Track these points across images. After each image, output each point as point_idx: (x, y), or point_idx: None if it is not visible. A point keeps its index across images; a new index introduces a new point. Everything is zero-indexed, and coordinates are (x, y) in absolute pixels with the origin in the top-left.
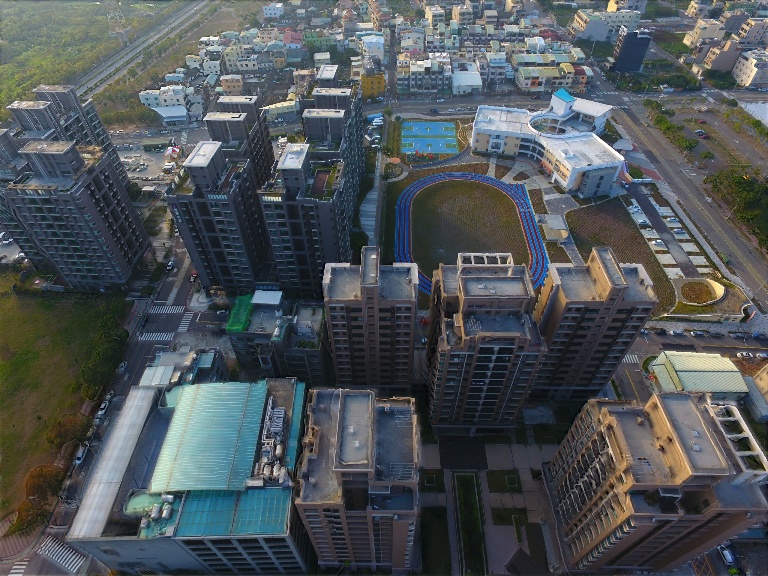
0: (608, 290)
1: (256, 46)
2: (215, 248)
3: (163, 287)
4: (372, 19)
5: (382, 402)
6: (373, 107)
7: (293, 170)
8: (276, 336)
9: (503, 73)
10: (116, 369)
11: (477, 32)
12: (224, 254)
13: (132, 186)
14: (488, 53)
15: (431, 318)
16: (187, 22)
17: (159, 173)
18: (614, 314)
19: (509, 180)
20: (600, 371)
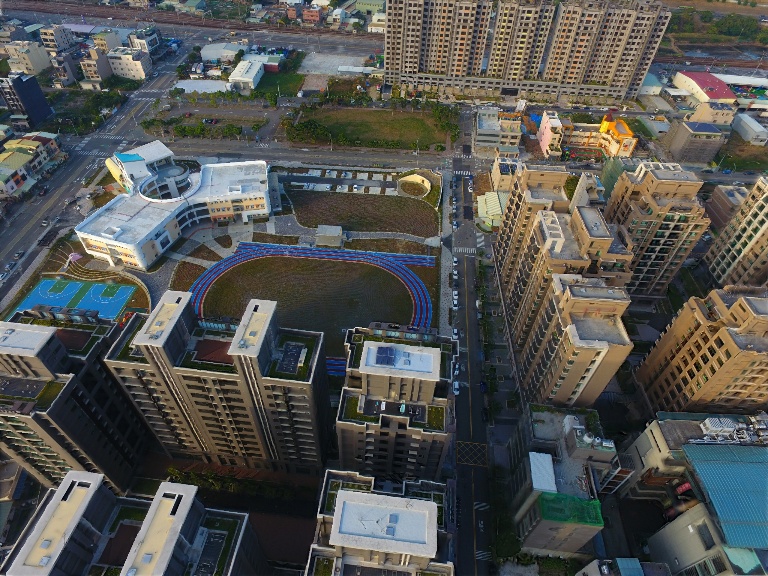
0: None
1: None
2: None
3: None
4: None
5: (706, 316)
6: None
7: None
8: None
9: None
10: None
11: None
12: None
13: None
14: None
15: None
16: None
17: None
18: None
19: (227, 251)
20: None
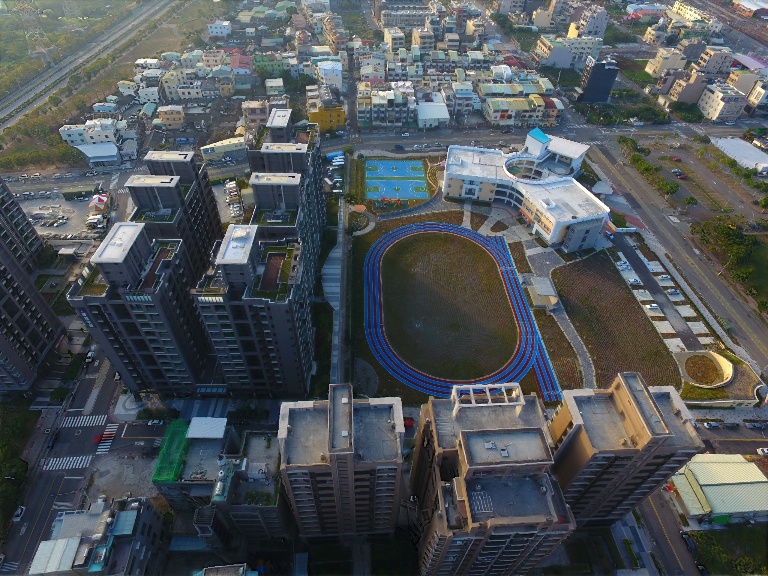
0: (647, 440)
1: (200, 71)
2: (141, 351)
3: (80, 388)
4: (328, 41)
5: None
6: (332, 143)
7: (237, 265)
8: (218, 495)
9: (470, 104)
10: (9, 519)
11: (440, 58)
12: (153, 357)
13: (45, 249)
14: (454, 83)
15: (421, 467)
16: (122, 39)
17: (82, 228)
18: (650, 460)
19: (486, 231)
20: None
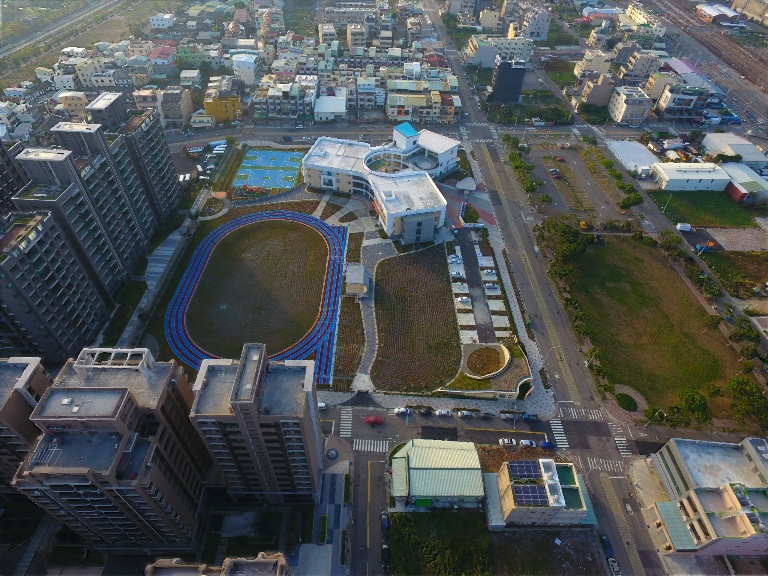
0: (230, 405)
1: (118, 60)
2: None
3: None
4: None
5: None
6: (224, 132)
7: None
8: None
9: (372, 100)
10: None
11: (358, 54)
12: None
13: None
14: (358, 78)
15: None
16: (68, 29)
17: None
18: (259, 428)
19: (333, 221)
20: (299, 477)
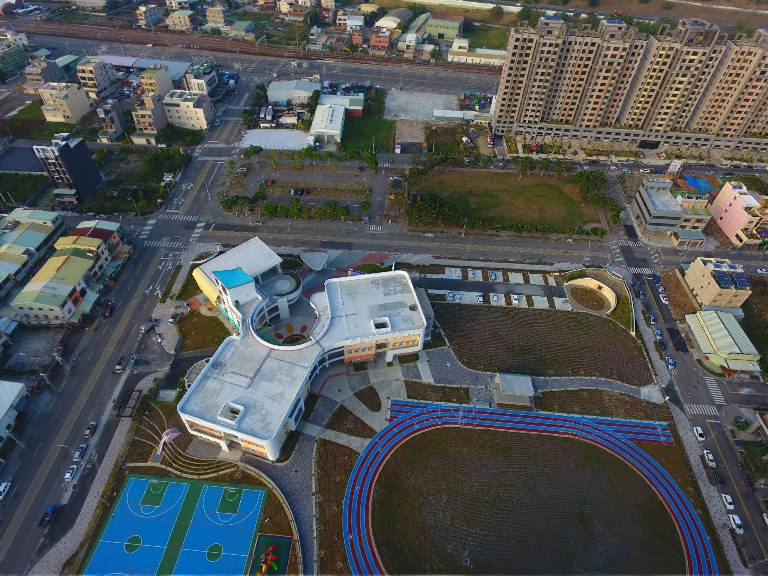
0: None
1: None
2: None
3: None
4: None
5: None
6: None
7: None
8: None
9: None
10: None
11: None
12: None
13: None
14: None
15: None
16: None
17: None
18: None
19: (379, 419)
20: None
